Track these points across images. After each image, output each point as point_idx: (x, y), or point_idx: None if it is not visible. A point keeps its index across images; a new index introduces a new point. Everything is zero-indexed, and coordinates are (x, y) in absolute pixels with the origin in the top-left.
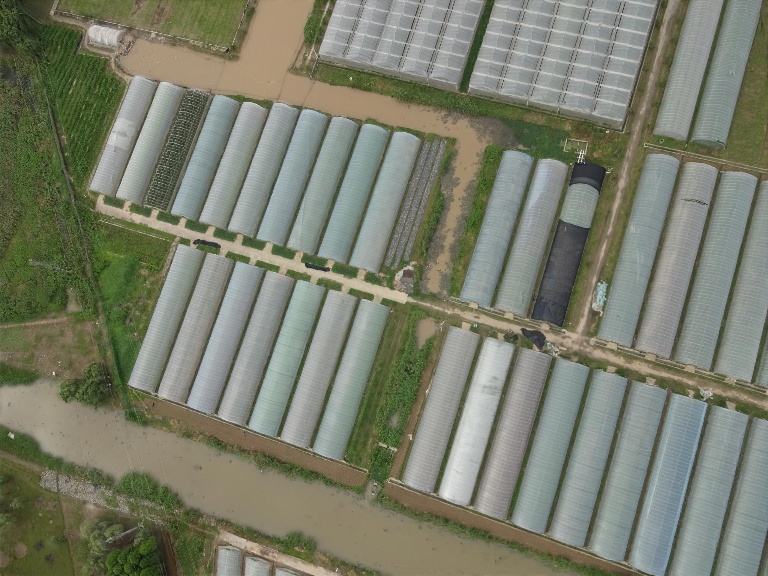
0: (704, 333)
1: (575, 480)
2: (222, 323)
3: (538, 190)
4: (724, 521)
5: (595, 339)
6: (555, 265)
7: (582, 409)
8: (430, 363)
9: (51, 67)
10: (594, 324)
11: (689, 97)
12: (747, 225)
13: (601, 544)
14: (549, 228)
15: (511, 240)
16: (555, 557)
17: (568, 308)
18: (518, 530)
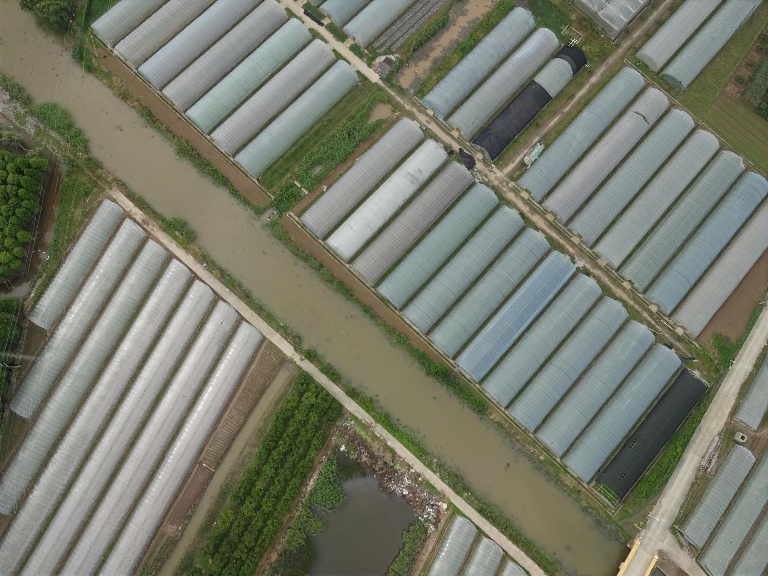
0: (600, 214)
1: (445, 277)
2: (206, 17)
3: (527, 47)
4: (545, 362)
5: (514, 184)
6: (511, 113)
7: (477, 230)
8: (371, 139)
9: None
10: (519, 172)
11: (675, 39)
12: (670, 156)
13: (441, 335)
14: (521, 81)
15: (486, 77)
16: (398, 332)
17: (505, 150)
18: (378, 300)
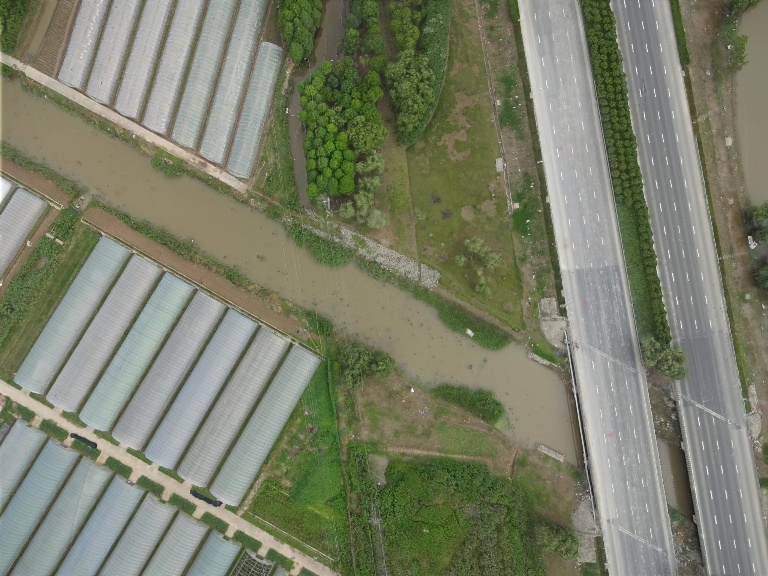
0: None
1: None
2: (196, 402)
3: None
4: None
5: None
6: None
7: None
8: None
9: None
10: None
11: None
12: None
13: None
14: None
15: None
16: None
17: None
18: None
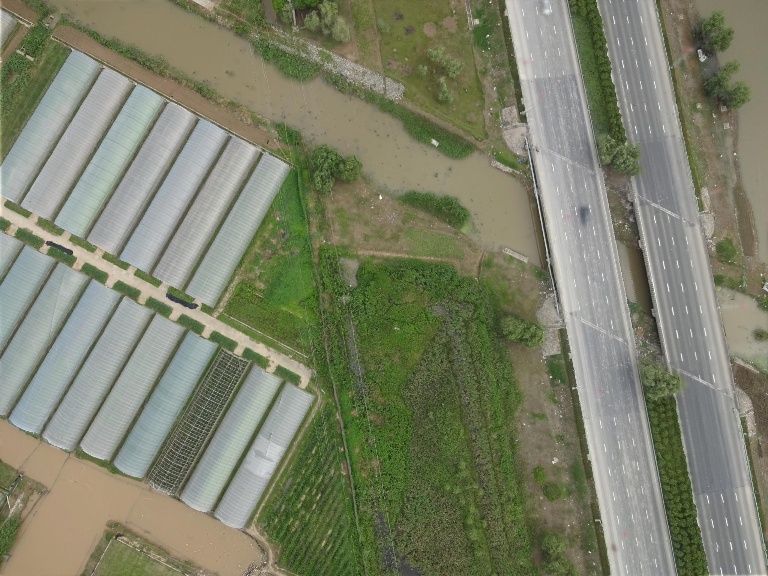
0: None
1: None
2: (169, 206)
3: None
4: None
5: None
6: None
7: None
8: None
9: (352, 572)
10: None
11: None
12: None
13: None
14: None
15: None
16: None
17: None
18: None
